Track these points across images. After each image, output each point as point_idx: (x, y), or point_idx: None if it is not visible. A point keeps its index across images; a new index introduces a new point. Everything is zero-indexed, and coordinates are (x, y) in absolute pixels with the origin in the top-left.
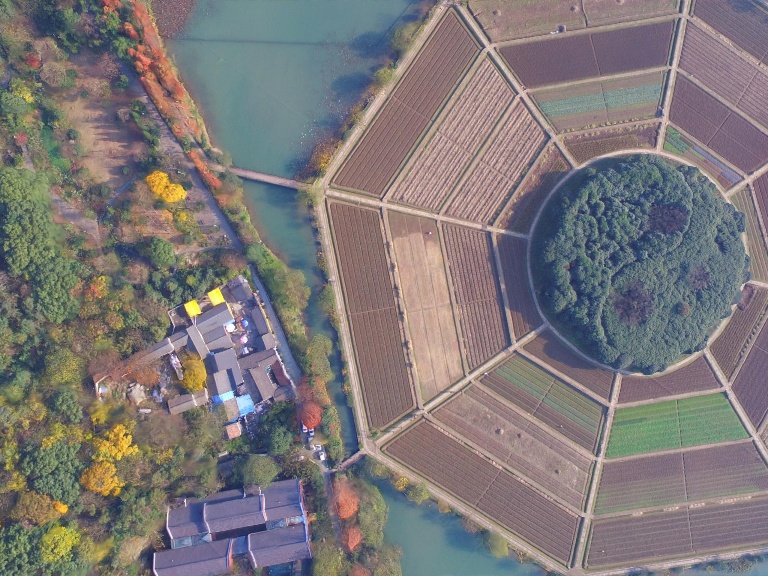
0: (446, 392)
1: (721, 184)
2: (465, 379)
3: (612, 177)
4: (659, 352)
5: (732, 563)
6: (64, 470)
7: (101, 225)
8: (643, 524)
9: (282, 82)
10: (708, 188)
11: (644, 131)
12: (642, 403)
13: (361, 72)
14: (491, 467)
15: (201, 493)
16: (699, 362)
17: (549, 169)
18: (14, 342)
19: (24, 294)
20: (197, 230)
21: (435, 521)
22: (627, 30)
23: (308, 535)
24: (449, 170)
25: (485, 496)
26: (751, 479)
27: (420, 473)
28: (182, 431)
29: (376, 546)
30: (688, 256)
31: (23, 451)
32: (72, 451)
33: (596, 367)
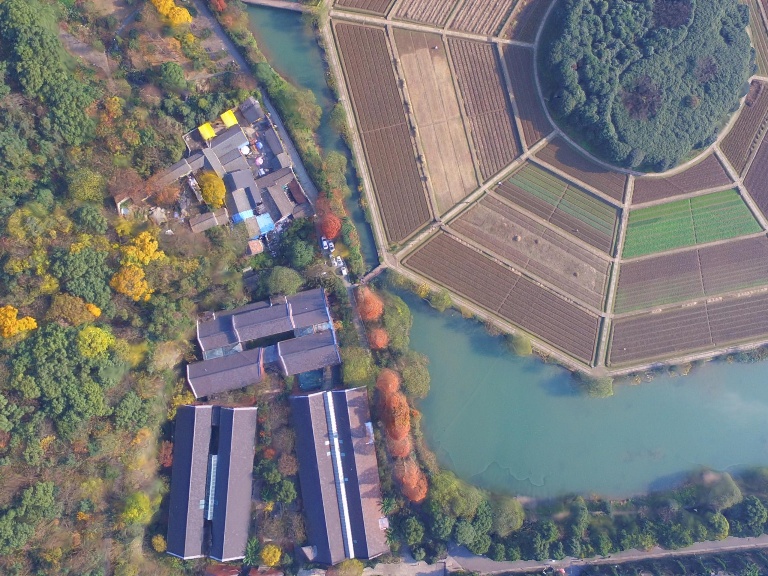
0: (462, 203)
1: None
2: (480, 189)
3: None
4: (670, 145)
5: (752, 353)
6: (94, 274)
7: (110, 57)
8: (662, 321)
9: None
10: None
11: None
12: (655, 203)
13: None
14: (510, 274)
15: (229, 303)
16: (710, 160)
17: None
18: (34, 164)
19: (40, 114)
20: (205, 57)
21: (459, 330)
22: None
23: (336, 339)
24: None
25: (506, 302)
26: (766, 271)
27: (441, 283)
28: (205, 247)
29: (403, 351)
30: (694, 49)
31: (53, 257)
32: (100, 257)
33: (608, 170)
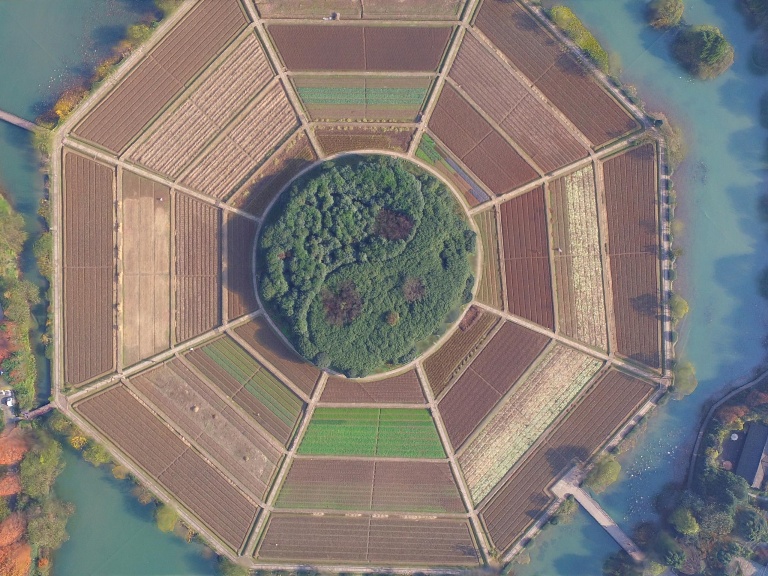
0: (148, 360)
1: (467, 201)
2: (169, 351)
3: (345, 173)
4: (358, 357)
5: None
6: None
7: None
8: (322, 525)
9: (41, 22)
10: (442, 201)
11: (399, 134)
12: (343, 405)
13: (123, 25)
14: (180, 442)
15: None
16: (409, 375)
17: (294, 156)
18: None
19: None
20: None
21: (115, 486)
22: (403, 29)
23: None
24: (193, 139)
25: (168, 470)
26: (439, 499)
27: (107, 436)
28: None
29: (41, 499)
30: (407, 266)
31: None
32: None
33: (304, 362)
